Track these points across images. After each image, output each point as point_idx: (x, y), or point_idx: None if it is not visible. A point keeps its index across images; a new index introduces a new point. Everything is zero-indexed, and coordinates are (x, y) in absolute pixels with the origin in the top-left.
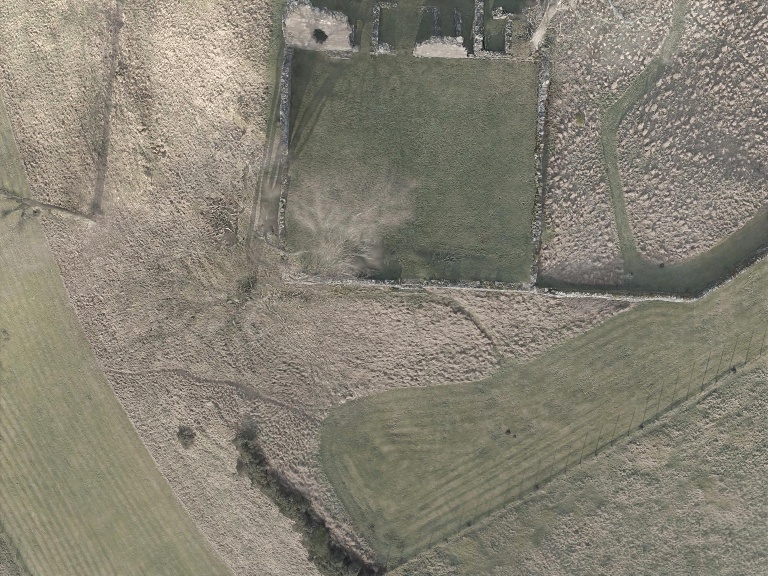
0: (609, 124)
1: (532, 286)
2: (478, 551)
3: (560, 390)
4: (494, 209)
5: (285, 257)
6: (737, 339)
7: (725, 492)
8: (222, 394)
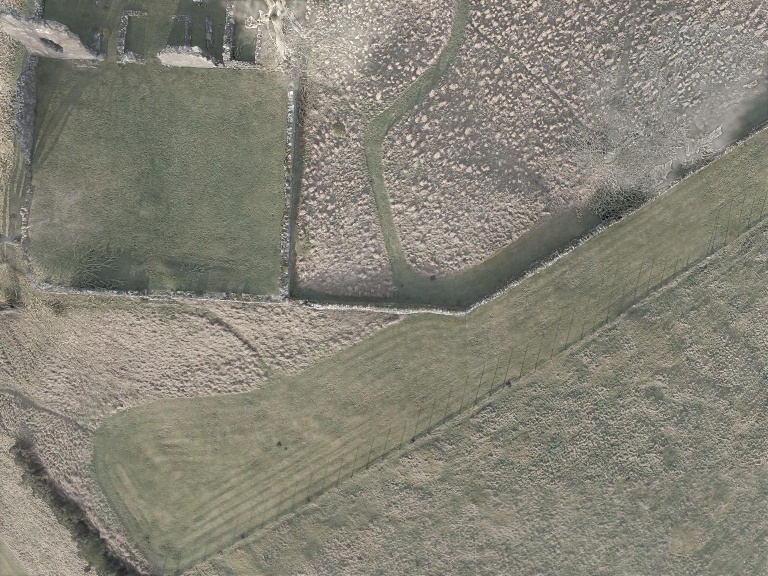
0: (374, 135)
1: (284, 298)
2: (252, 564)
3: (330, 402)
4: (243, 220)
5: (31, 267)
6: (511, 353)
7: (499, 507)
8: (4, 402)
